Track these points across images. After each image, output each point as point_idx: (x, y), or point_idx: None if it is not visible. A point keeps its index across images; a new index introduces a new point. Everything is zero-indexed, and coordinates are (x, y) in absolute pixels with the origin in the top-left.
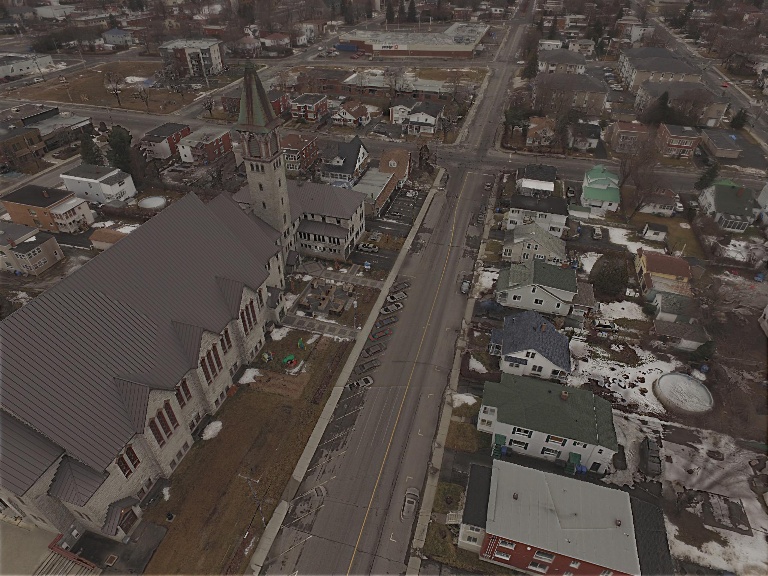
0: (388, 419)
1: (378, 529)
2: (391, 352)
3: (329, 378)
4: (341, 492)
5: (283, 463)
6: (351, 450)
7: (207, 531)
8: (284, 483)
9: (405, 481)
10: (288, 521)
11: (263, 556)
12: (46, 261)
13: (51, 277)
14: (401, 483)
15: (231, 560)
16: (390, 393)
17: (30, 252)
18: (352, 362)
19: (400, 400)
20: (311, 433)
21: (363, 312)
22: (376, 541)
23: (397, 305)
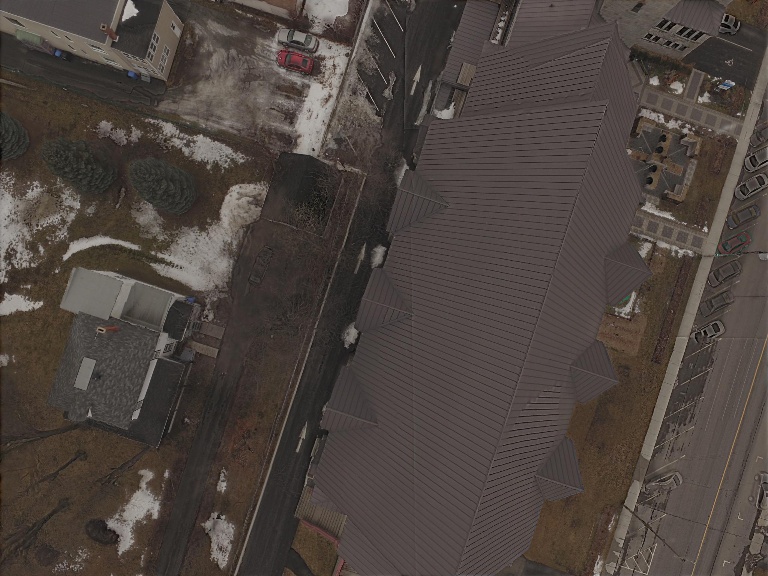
0: (742, 387)
1: (728, 509)
2: (748, 279)
3: (671, 324)
4: (692, 473)
5: (630, 441)
6: (700, 426)
7: (570, 510)
8: (634, 463)
9: (755, 462)
10: (642, 500)
11: (625, 531)
12: (167, 49)
13: (191, 84)
14: (751, 464)
15: (599, 537)
16: (745, 349)
17: (148, 49)
18: (697, 296)
19: (757, 360)
20: (655, 403)
21: (710, 195)
22: (726, 520)
23: (760, 180)
